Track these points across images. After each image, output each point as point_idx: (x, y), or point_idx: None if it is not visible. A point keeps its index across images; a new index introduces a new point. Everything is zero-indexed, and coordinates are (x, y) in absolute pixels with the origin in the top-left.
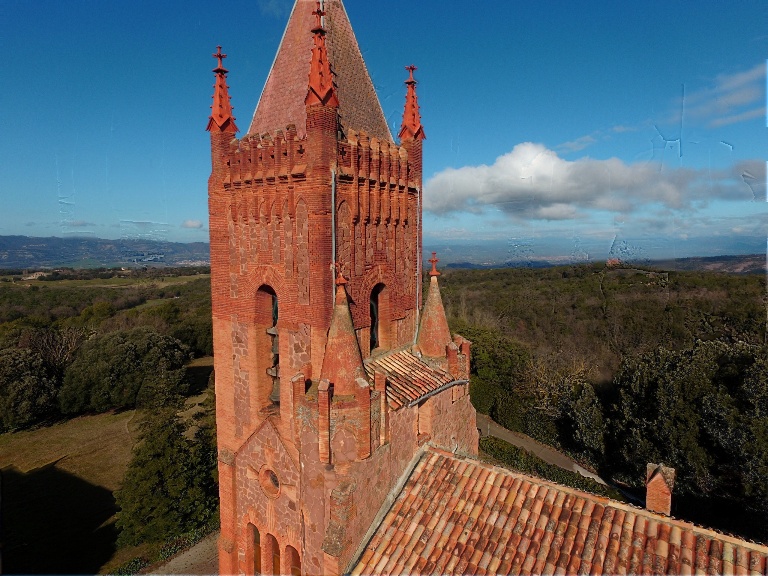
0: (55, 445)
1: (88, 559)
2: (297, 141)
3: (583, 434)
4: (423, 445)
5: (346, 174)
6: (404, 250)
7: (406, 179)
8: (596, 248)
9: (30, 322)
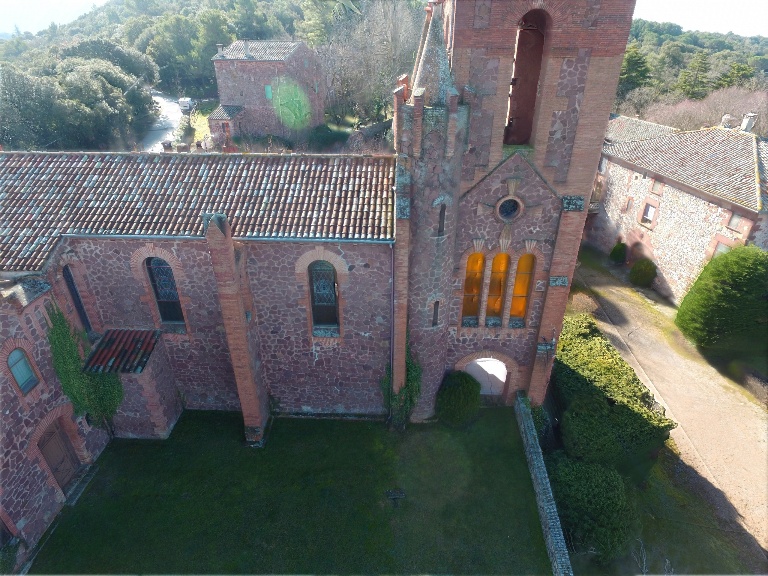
0: None
1: None
2: None
3: None
4: None
5: None
6: None
7: None
8: None
9: None
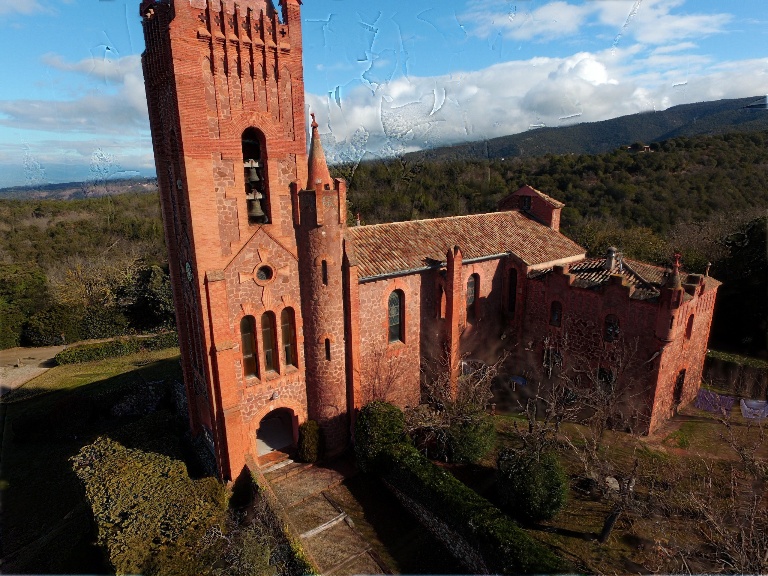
0: None
1: None
2: (279, 24)
3: (167, 305)
4: None
5: None
6: None
7: None
8: (45, 158)
9: None
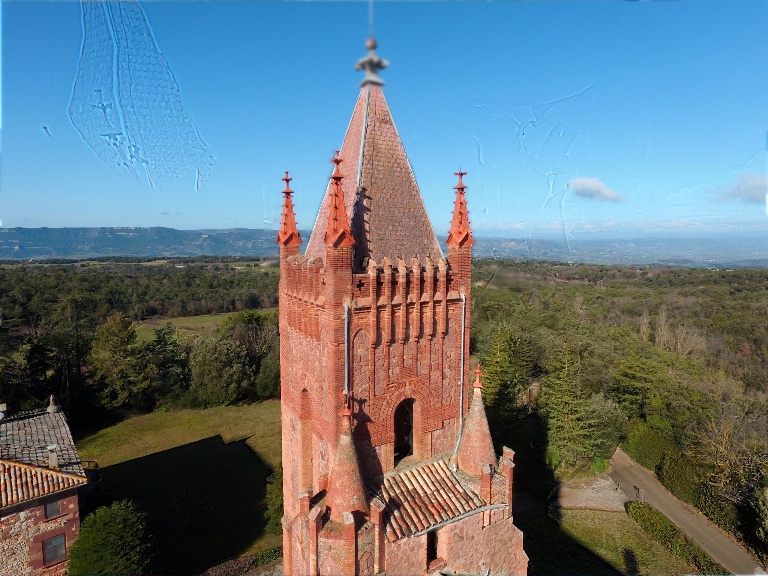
0: (249, 423)
1: (247, 535)
2: (321, 274)
3: None
4: (434, 572)
5: (361, 306)
6: (443, 361)
7: (444, 292)
8: None
9: (241, 319)
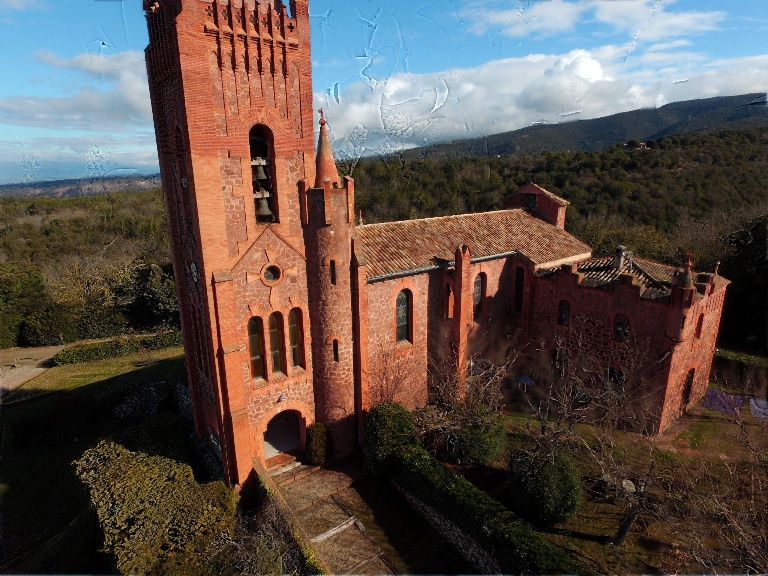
0: None
1: None
2: None
3: (166, 304)
4: None
5: None
6: None
7: None
8: (40, 155)
9: None
